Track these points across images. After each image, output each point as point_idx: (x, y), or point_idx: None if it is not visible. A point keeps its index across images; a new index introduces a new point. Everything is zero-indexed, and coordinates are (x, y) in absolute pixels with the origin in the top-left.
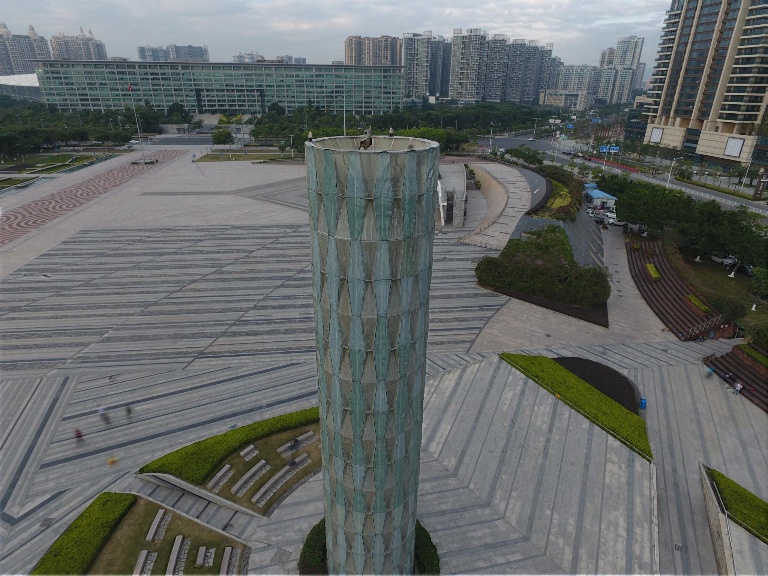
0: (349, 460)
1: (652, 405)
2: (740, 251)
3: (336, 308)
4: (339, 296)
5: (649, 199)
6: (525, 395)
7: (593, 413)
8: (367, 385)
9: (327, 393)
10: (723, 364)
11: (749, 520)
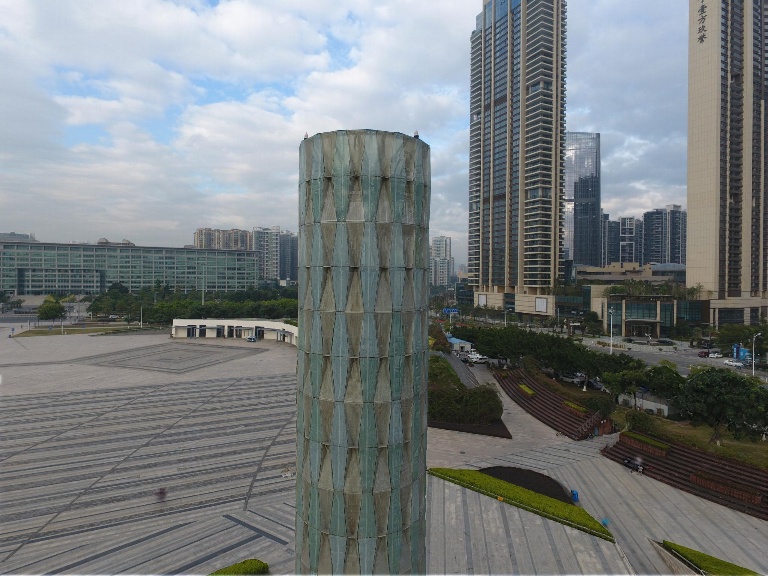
0: (353, 535)
1: (582, 497)
2: (585, 366)
3: (343, 307)
4: (348, 291)
5: (503, 334)
6: (468, 505)
7: (541, 507)
8: (380, 406)
9: (323, 436)
10: (618, 452)
11: (723, 573)
